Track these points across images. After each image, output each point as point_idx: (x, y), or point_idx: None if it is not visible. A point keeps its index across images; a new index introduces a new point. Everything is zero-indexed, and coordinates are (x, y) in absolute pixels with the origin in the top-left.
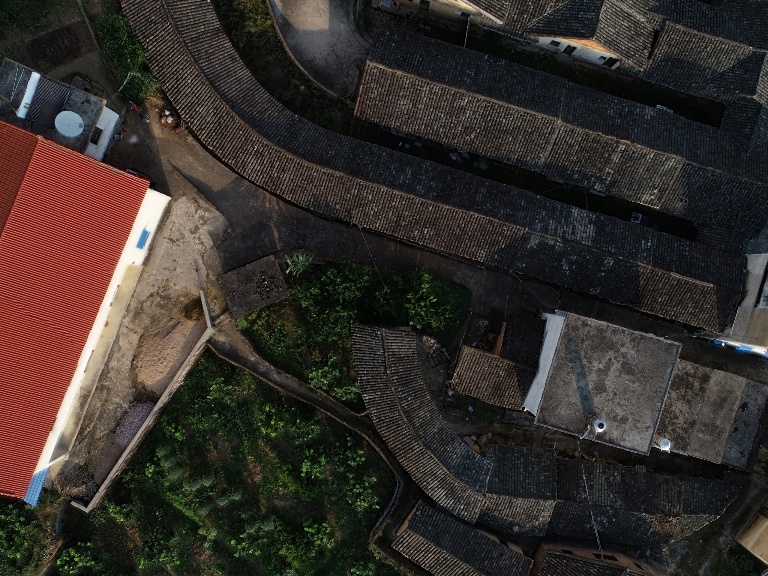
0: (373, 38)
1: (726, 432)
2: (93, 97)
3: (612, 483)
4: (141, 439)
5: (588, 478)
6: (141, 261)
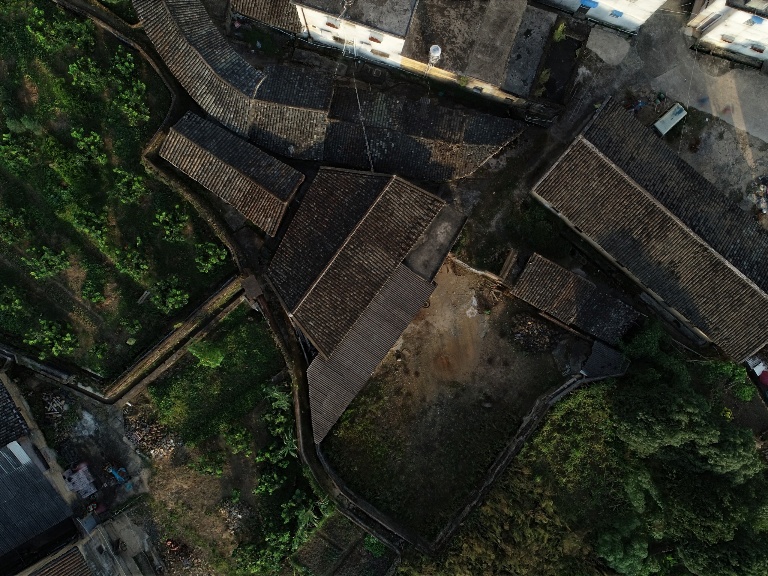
0: None
1: (506, 54)
2: None
3: (393, 110)
4: None
5: (369, 104)
6: None
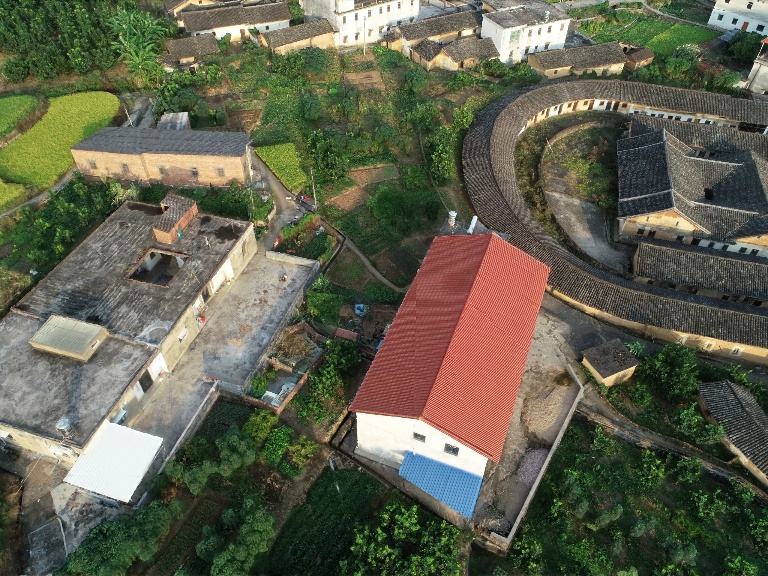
0: (623, 252)
1: None
2: (502, 234)
3: None
4: (538, 485)
5: None
6: None
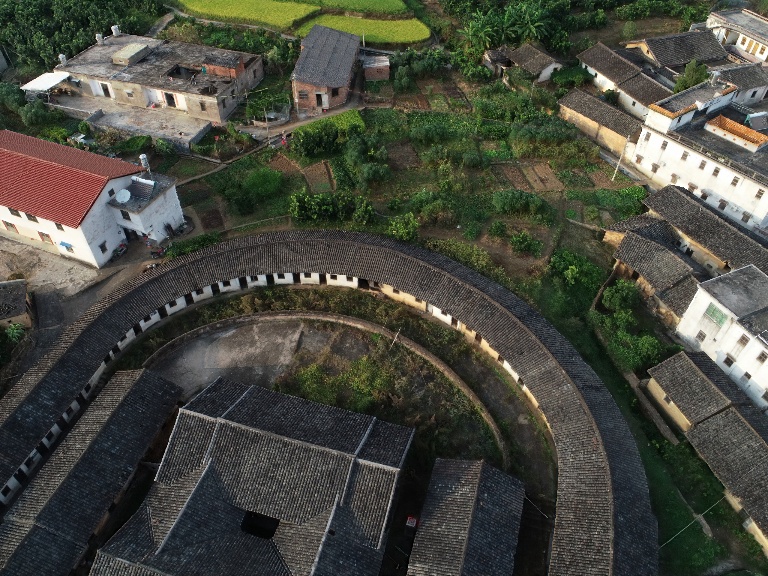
0: None
1: None
2: (141, 209)
3: None
4: None
5: None
6: (62, 252)
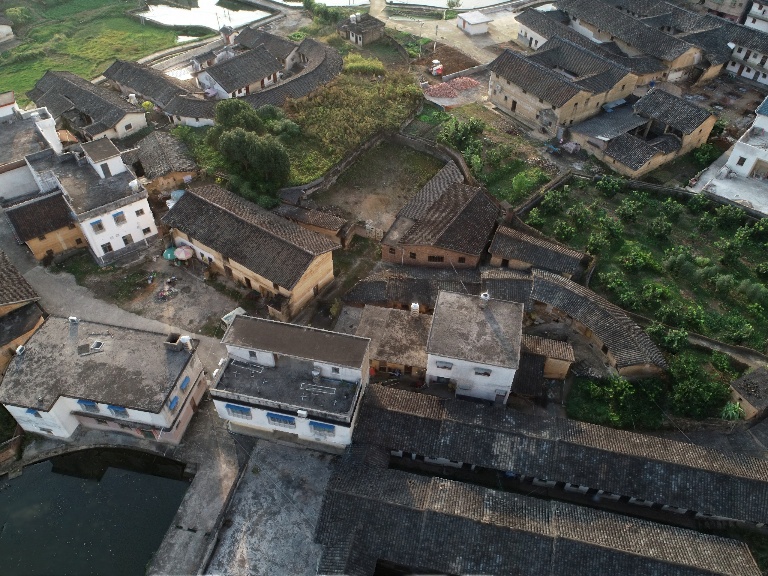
0: None
1: (362, 322)
2: None
3: None
4: None
5: None
6: None
